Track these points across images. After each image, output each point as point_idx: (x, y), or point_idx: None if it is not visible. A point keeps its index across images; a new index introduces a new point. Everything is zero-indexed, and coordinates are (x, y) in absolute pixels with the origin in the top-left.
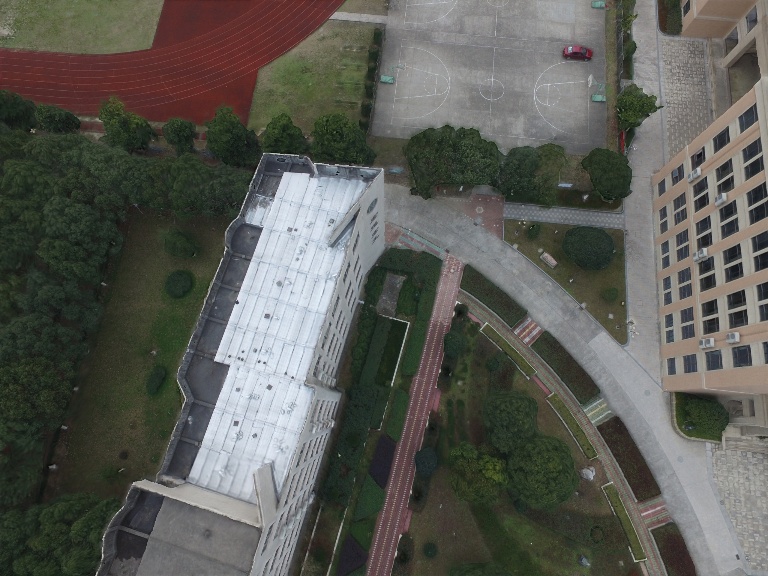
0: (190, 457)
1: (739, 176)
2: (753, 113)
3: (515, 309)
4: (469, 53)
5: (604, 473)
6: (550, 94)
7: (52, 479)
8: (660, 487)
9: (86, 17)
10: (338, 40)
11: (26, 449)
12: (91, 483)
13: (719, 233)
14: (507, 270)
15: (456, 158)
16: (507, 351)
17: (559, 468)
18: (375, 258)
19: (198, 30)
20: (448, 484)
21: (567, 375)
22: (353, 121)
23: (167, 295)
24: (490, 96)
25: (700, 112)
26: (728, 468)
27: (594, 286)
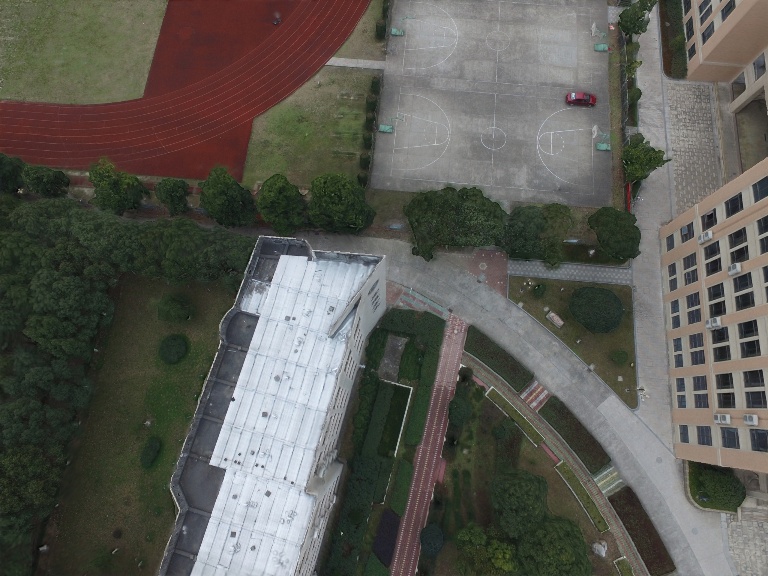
0: (185, 571)
1: (754, 248)
2: (767, 184)
3: (521, 373)
4: (470, 100)
5: (616, 547)
6: (553, 142)
7: (43, 561)
8: (674, 561)
9: (75, 65)
10: (335, 87)
11: (14, 544)
12: (84, 564)
13: (733, 304)
14: (512, 330)
15: (459, 221)
16: (514, 417)
17: (572, 560)
18: (376, 320)
19: (191, 78)
20: (455, 561)
21: (576, 443)
22: (351, 173)
23: (161, 361)
24: (492, 145)
25: (707, 160)
26: (744, 540)
27: (602, 347)
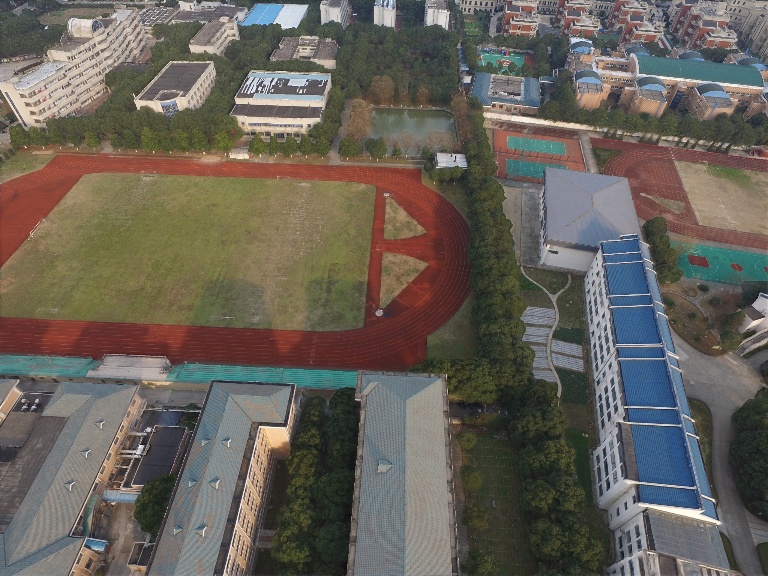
0: None
1: None
2: None
3: None
4: None
5: None
6: None
7: None
8: None
9: None
10: (3, 177)
11: None
12: None
13: None
14: None
15: None
16: None
17: None
18: None
19: None
20: None
21: None
22: None
23: None
24: None
25: None
26: None
27: None
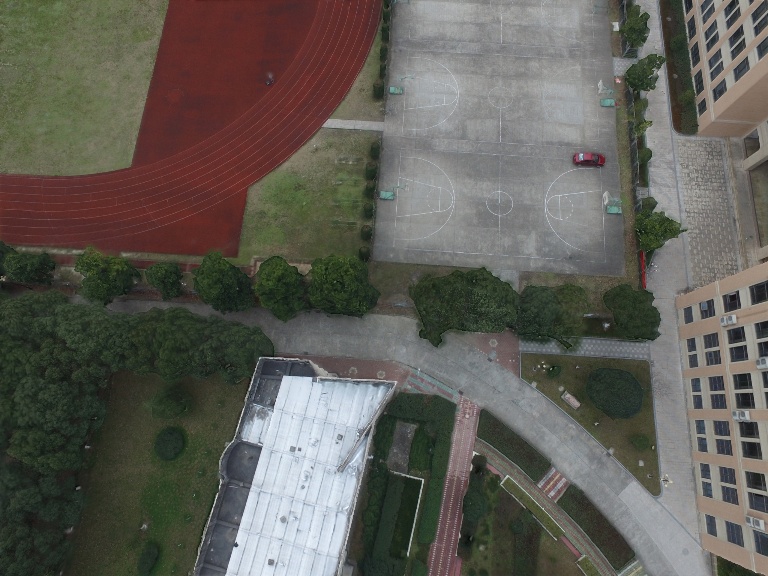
0: None
1: None
2: None
3: (538, 461)
4: (473, 162)
5: None
6: (562, 206)
7: None
8: None
9: (59, 133)
10: (332, 152)
11: None
12: None
13: (763, 399)
14: (526, 413)
15: (469, 307)
16: (531, 510)
17: None
18: None
19: (181, 144)
20: None
21: (598, 537)
22: (352, 245)
23: (157, 457)
24: (498, 211)
25: (722, 222)
26: None
27: (621, 429)
